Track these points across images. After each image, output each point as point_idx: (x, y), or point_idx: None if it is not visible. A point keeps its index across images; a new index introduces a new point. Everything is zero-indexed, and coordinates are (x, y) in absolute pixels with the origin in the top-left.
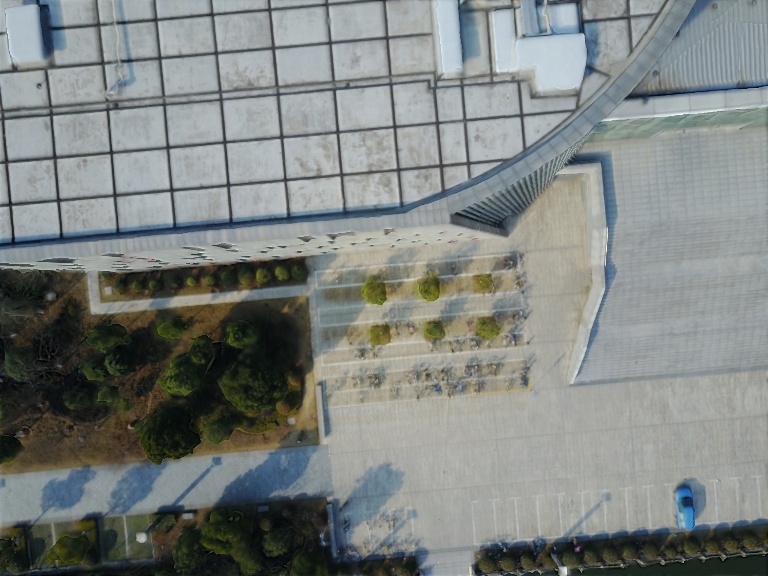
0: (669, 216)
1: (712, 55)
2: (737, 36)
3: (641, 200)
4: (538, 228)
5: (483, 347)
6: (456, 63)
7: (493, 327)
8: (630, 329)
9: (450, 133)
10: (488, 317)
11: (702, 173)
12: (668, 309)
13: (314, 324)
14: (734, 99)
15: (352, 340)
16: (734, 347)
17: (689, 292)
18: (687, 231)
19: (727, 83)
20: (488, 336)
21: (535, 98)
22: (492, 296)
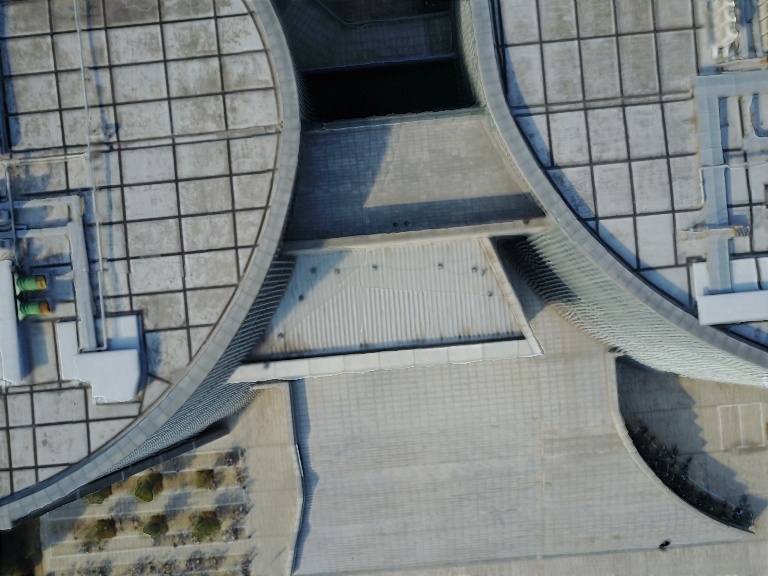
0: (361, 430)
1: (335, 318)
2: (359, 300)
3: (333, 415)
4: (259, 425)
5: (206, 541)
6: (14, 378)
7: (208, 527)
8: (341, 529)
9: (20, 437)
10: (210, 512)
11: (392, 389)
12: (376, 511)
13: (43, 518)
14: (352, 364)
15: (79, 534)
16: (447, 545)
17: (393, 497)
18: (381, 444)
19: (349, 346)
20: (208, 532)
21: (100, 404)
22: (213, 492)
